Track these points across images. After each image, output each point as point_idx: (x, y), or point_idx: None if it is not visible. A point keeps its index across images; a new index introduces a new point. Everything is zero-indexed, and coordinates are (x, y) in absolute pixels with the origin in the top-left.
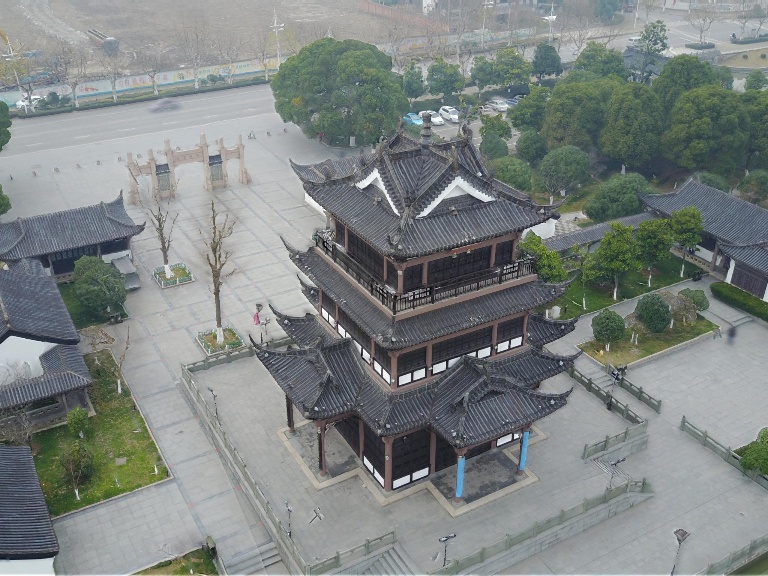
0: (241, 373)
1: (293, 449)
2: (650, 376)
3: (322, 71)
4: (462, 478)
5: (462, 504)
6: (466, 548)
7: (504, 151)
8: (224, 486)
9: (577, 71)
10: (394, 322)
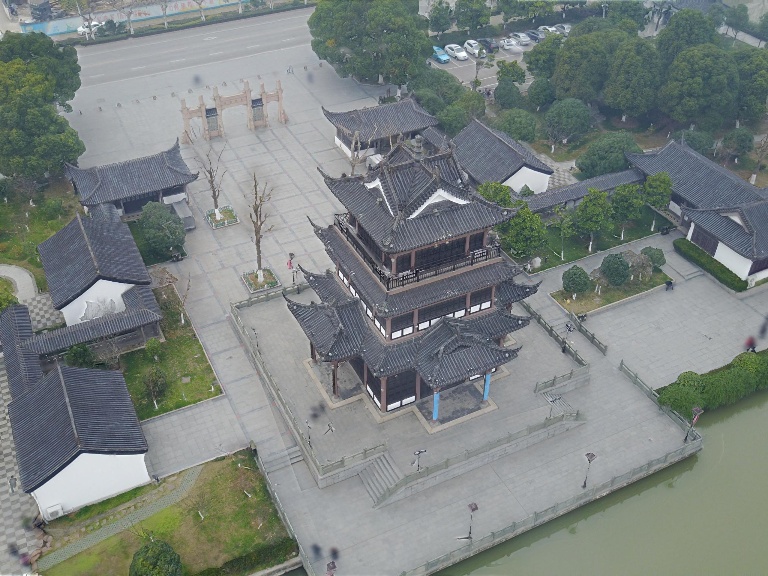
0: (277, 310)
1: (315, 376)
2: (605, 323)
3: (354, 17)
4: (437, 407)
5: (437, 425)
6: (436, 458)
7: (516, 97)
8: (263, 402)
9: (591, 18)
10: (388, 296)
